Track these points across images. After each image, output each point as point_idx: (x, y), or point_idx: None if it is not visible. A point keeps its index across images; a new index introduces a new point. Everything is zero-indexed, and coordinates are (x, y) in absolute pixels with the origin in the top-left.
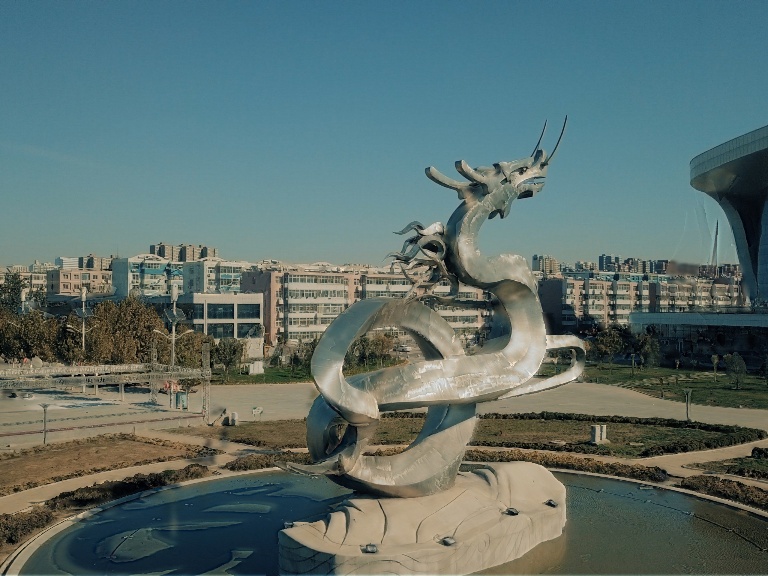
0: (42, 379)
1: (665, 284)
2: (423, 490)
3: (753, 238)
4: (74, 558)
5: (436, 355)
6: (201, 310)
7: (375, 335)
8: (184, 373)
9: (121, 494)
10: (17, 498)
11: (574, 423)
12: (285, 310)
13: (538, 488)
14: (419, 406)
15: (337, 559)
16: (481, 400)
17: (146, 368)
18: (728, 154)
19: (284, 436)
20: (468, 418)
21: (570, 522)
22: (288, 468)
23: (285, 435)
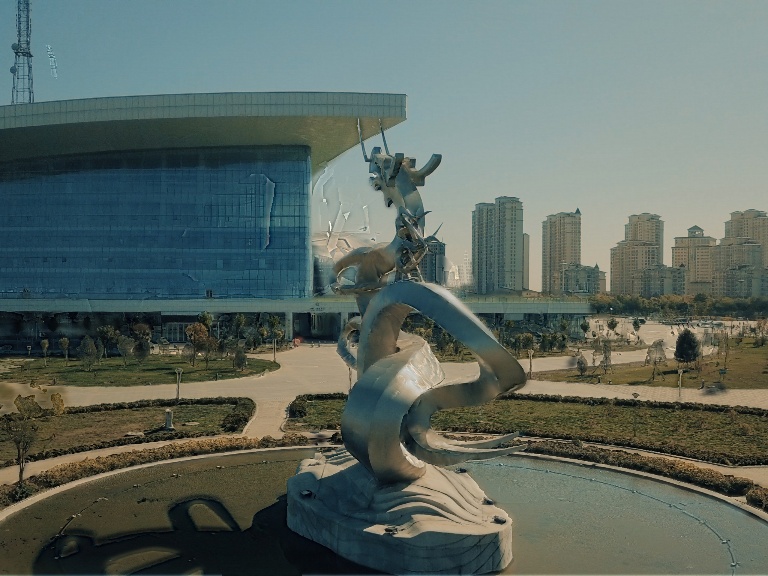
0: None
1: None
2: None
3: None
4: None
5: (388, 338)
6: None
7: None
8: None
9: None
10: None
11: (76, 417)
12: None
13: None
14: None
15: (500, 536)
16: None
17: None
18: None
19: None
20: None
21: None
22: None
23: None
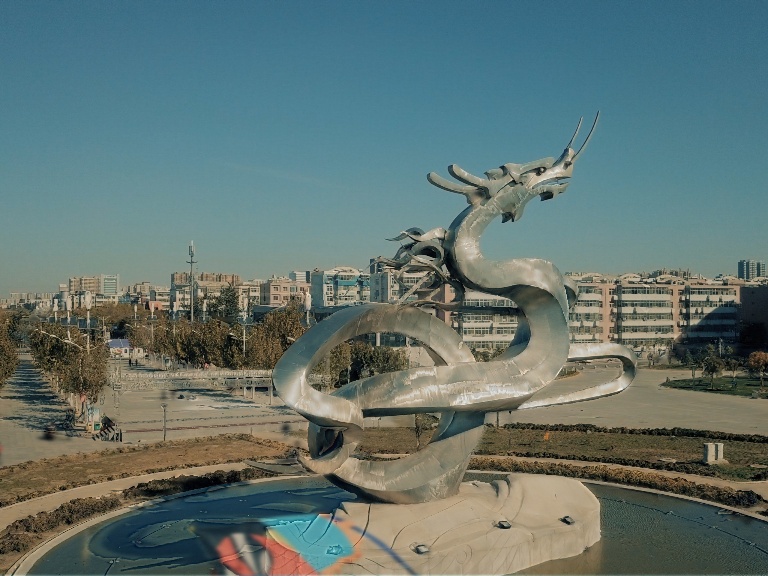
0: (171, 381)
1: None
2: (416, 497)
3: None
4: (108, 540)
5: (442, 362)
6: None
7: None
8: None
9: (193, 488)
10: (105, 486)
11: (705, 441)
12: (460, 320)
13: (561, 503)
14: (410, 412)
15: (301, 558)
16: (485, 408)
17: None
18: None
19: (389, 442)
20: (475, 427)
21: (606, 542)
22: None
23: (391, 441)
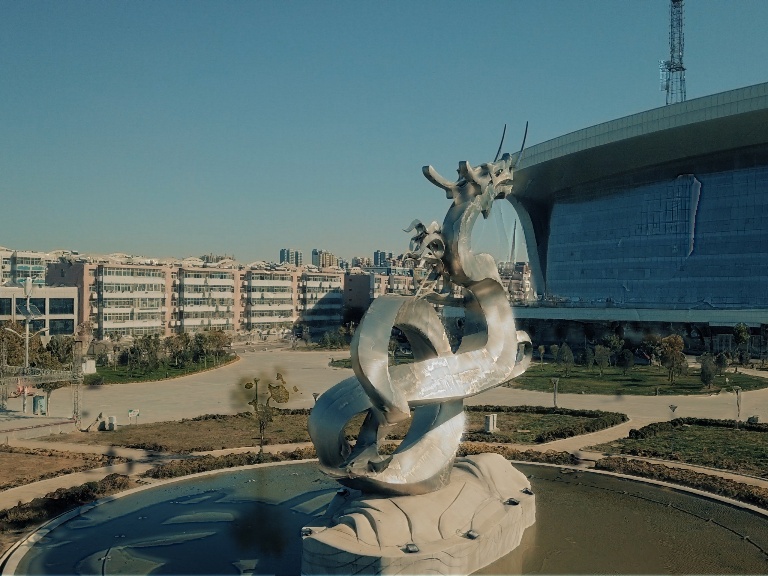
0: None
1: None
2: (430, 486)
3: (541, 238)
4: None
5: (429, 352)
6: (8, 305)
7: (210, 331)
8: (55, 375)
9: (55, 512)
10: None
11: None
12: (99, 305)
13: (510, 477)
14: (428, 403)
15: (383, 561)
16: None
17: None
18: (527, 160)
19: (176, 439)
20: (458, 413)
21: None
22: (329, 472)
23: (176, 438)
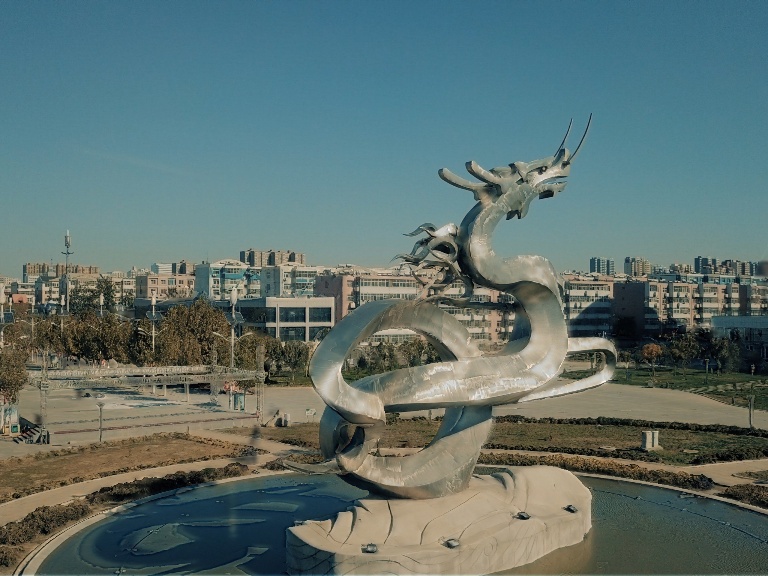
0: (101, 379)
1: (754, 286)
2: (433, 492)
3: None
4: (98, 549)
5: (451, 357)
6: (273, 314)
7: None
8: (238, 375)
9: (159, 490)
10: (62, 492)
11: (631, 429)
12: None
13: (559, 493)
14: (429, 408)
15: (337, 558)
16: (495, 402)
17: (206, 370)
18: None
19: None
20: (483, 420)
21: (596, 529)
22: None
23: None
